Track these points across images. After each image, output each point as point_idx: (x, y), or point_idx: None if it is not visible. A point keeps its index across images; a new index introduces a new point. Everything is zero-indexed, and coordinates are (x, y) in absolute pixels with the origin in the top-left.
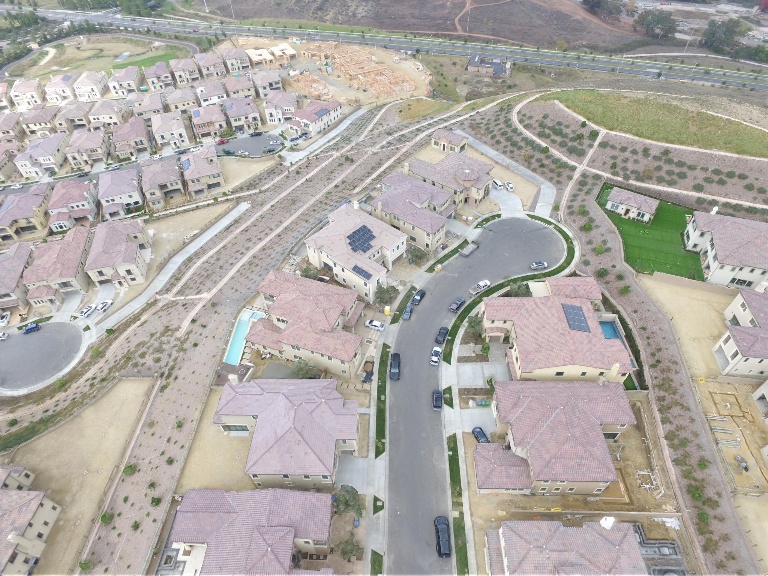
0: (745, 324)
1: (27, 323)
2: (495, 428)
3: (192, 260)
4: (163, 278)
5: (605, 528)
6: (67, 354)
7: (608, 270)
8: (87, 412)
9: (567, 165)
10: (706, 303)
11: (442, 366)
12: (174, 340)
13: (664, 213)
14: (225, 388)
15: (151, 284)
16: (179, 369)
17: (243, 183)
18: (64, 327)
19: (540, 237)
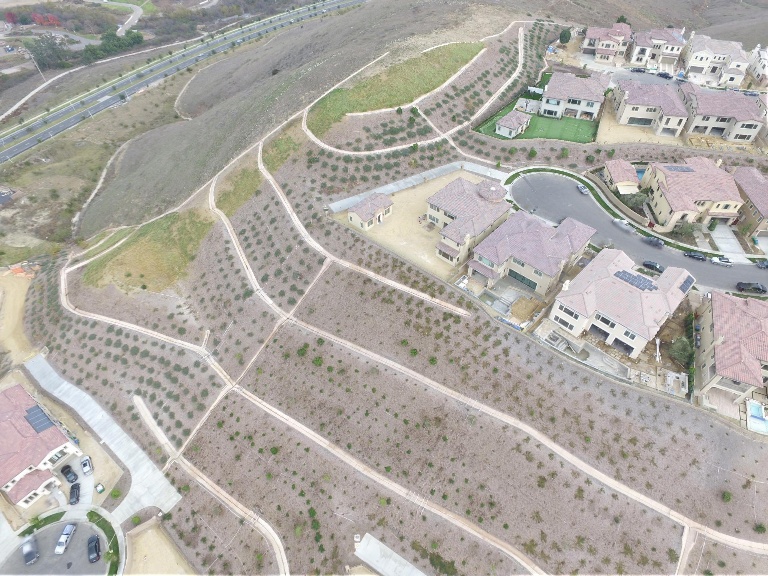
0: (644, 115)
1: None
2: None
3: None
4: None
5: None
6: None
7: None
8: None
9: (440, 143)
10: (612, 127)
11: None
12: None
13: None
14: None
15: None
16: None
17: None
18: None
19: (540, 183)
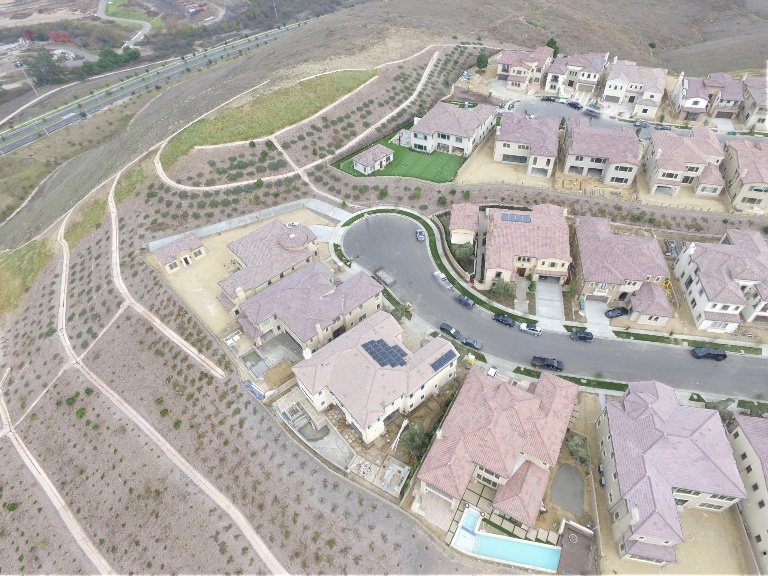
0: (517, 152)
1: None
2: (604, 303)
3: None
4: None
5: (694, 252)
6: None
7: None
8: None
9: (290, 178)
10: (484, 164)
11: None
12: None
13: None
14: (645, 533)
15: None
16: None
17: None
18: None
19: (380, 226)
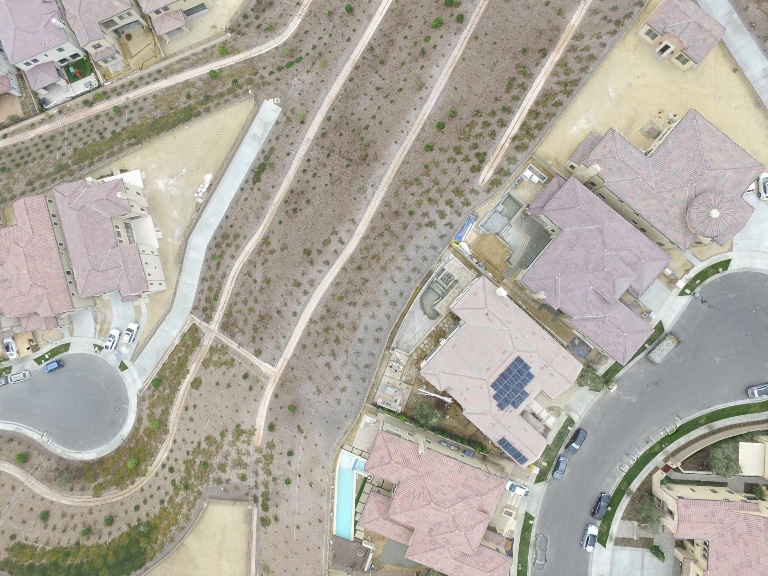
0: None
1: (42, 354)
2: None
3: (223, 255)
4: (190, 280)
5: None
6: (117, 405)
7: None
8: (189, 540)
9: None
10: None
11: (595, 548)
12: (254, 451)
13: None
14: None
15: (177, 291)
16: (276, 507)
17: (245, 2)
18: (93, 363)
19: None
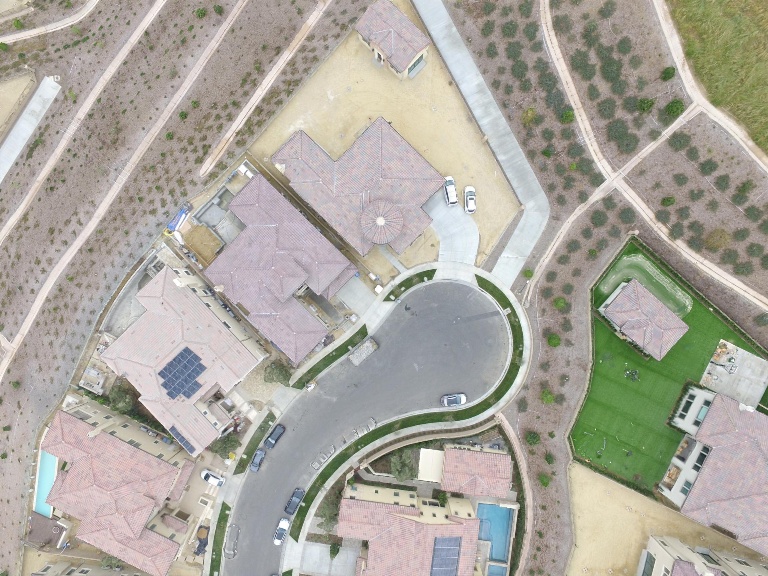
0: None
1: None
2: None
3: None
4: None
5: None
6: None
7: (542, 437)
8: None
9: (590, 169)
10: (638, 518)
11: (287, 542)
12: None
13: (689, 332)
14: None
15: None
16: None
17: None
18: None
19: (478, 336)
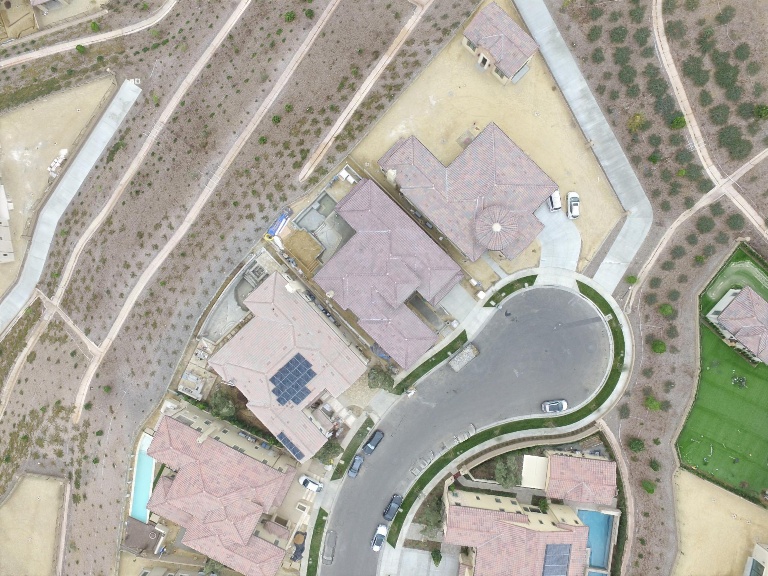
0: None
1: None
2: None
3: (69, 232)
4: (38, 254)
5: None
6: None
7: (646, 444)
8: (2, 512)
9: (699, 175)
10: (744, 525)
11: (385, 548)
12: (71, 429)
13: None
14: None
15: (25, 264)
16: (85, 485)
17: None
18: None
19: (579, 342)
